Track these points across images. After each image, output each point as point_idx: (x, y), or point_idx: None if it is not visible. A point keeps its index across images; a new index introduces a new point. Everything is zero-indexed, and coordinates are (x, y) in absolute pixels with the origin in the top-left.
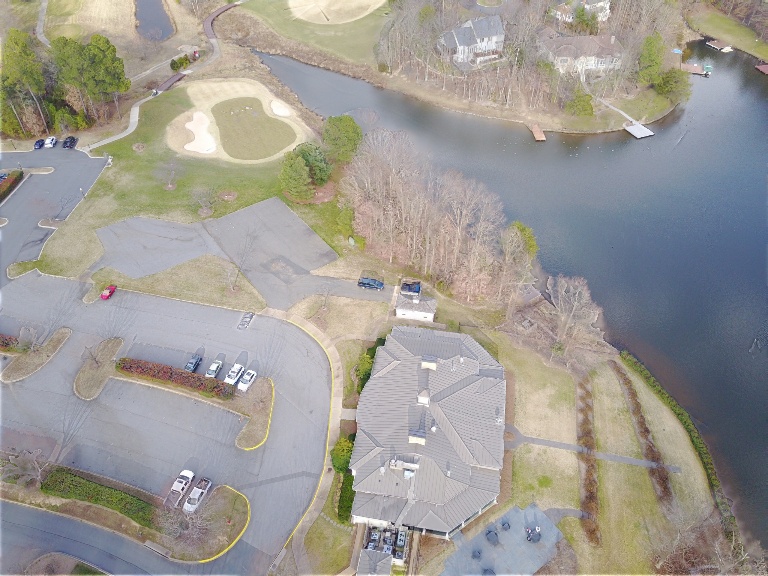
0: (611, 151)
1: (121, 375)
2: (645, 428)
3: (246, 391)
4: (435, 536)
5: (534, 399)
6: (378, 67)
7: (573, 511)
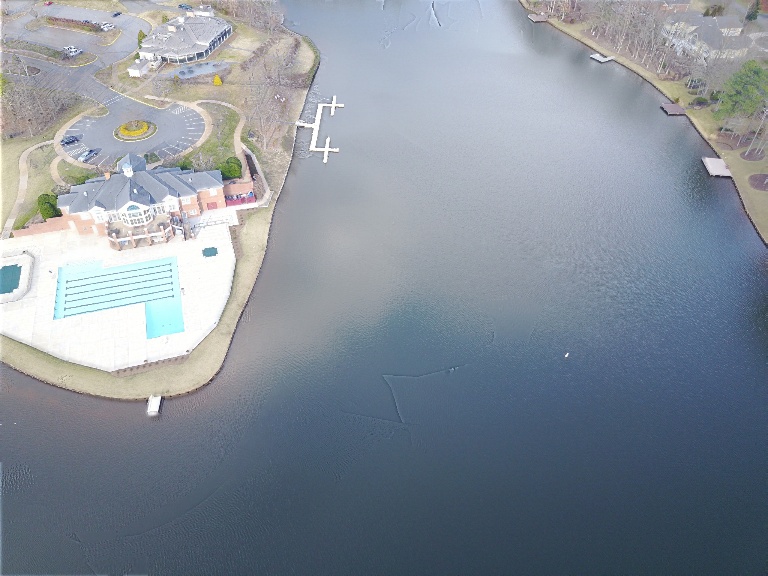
0: None
1: (49, 25)
2: (293, 52)
3: (107, 31)
4: (174, 64)
5: (244, 40)
6: None
7: (239, 63)
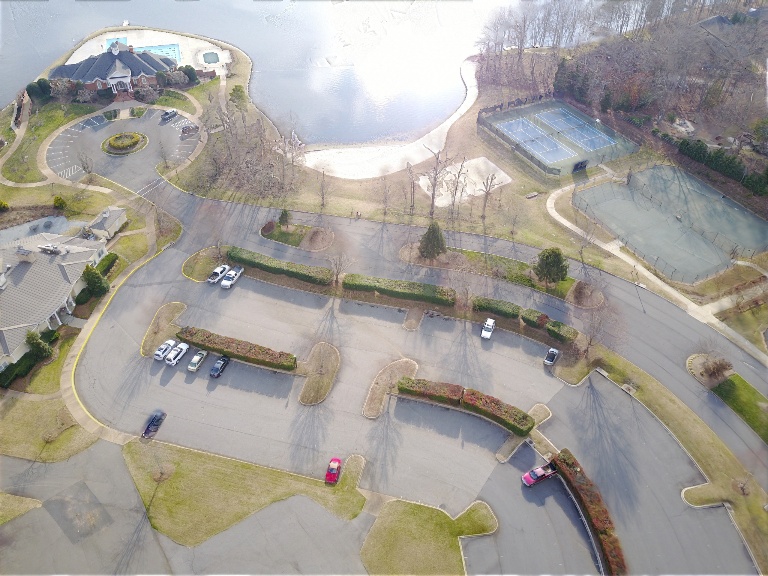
0: None
1: None
2: None
3: None
4: None
5: None
6: None
7: None
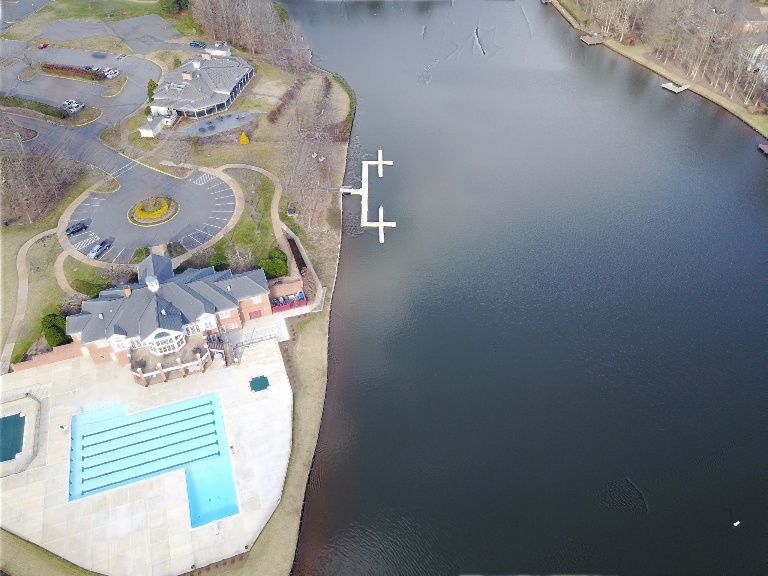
0: (401, 10)
1: (45, 73)
2: (325, 95)
3: (112, 78)
4: (191, 118)
5: (268, 83)
6: None
7: (266, 113)
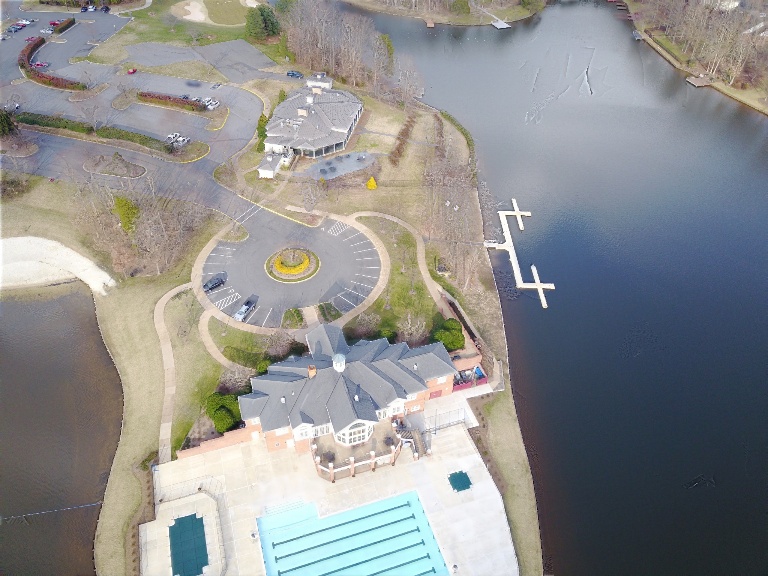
0: (484, 41)
1: (140, 101)
2: (441, 135)
3: (213, 110)
4: (308, 157)
5: (380, 120)
6: None
7: (386, 154)
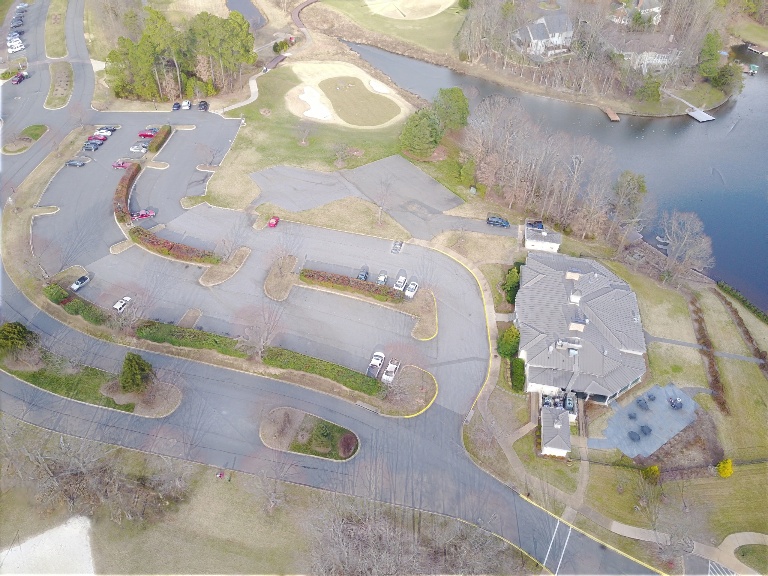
0: (674, 134)
1: (303, 283)
2: (750, 336)
3: (412, 298)
4: (596, 403)
5: (655, 311)
6: (459, 56)
7: (704, 389)
